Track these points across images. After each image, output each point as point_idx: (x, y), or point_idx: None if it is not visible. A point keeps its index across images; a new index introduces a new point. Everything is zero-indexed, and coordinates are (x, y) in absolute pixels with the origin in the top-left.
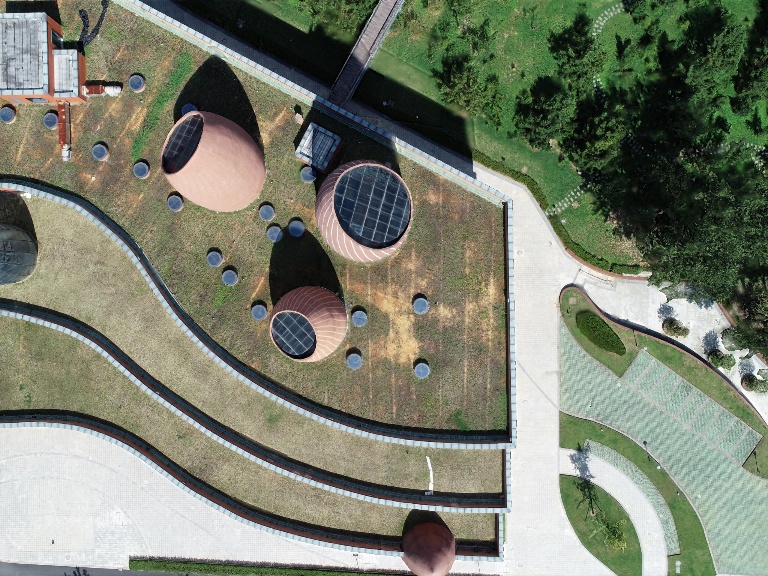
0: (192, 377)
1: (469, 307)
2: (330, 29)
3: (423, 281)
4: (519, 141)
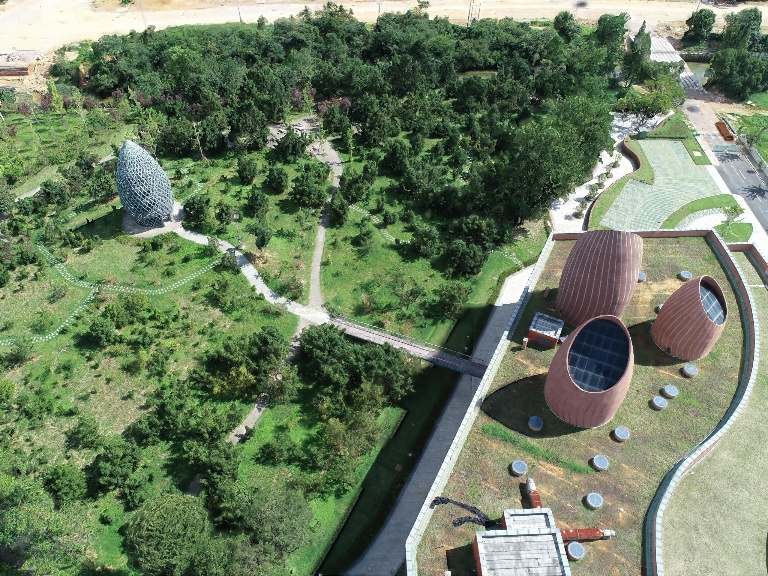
0: (767, 443)
1: None
2: (419, 371)
3: None
4: (476, 280)
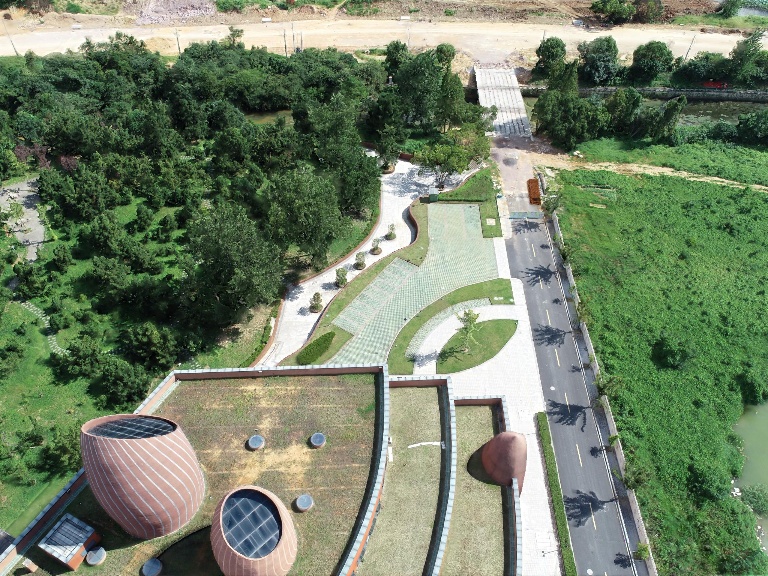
0: None
1: (264, 404)
2: None
3: (234, 442)
4: None
